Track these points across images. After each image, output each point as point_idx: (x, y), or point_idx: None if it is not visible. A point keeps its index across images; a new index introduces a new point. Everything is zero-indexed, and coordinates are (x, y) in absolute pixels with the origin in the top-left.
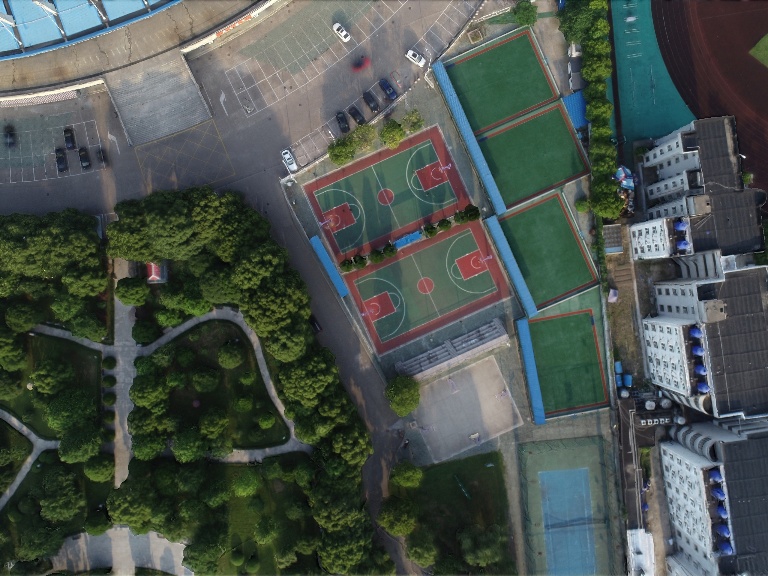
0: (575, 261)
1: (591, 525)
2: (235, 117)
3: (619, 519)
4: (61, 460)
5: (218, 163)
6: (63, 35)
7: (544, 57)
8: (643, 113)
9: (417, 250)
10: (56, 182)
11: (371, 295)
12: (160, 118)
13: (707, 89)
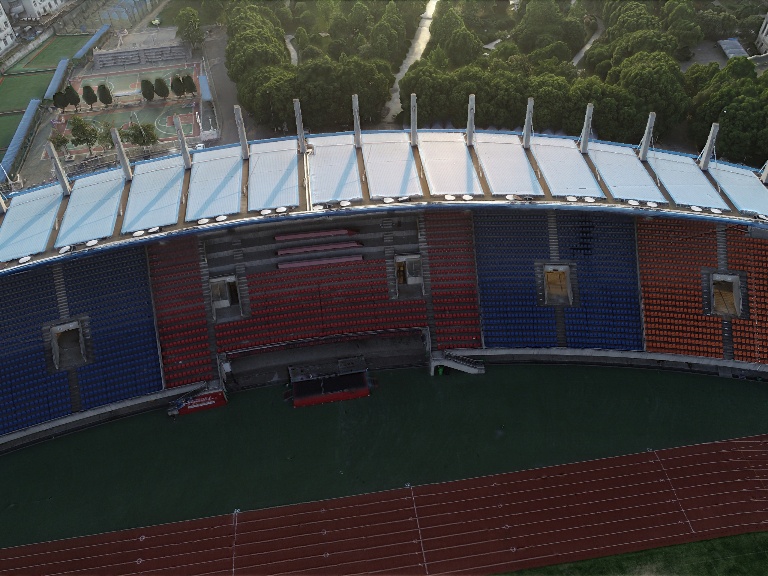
0: (8, 86)
1: (115, 5)
2: None
3: (94, 2)
4: None
5: None
6: None
7: None
8: None
9: None
10: None
11: None
12: None
13: None
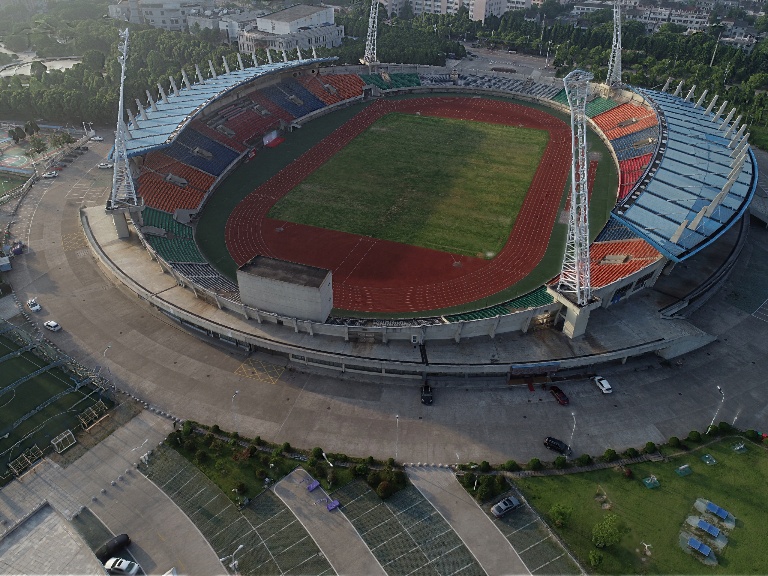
0: None
1: None
2: None
3: None
4: (114, 61)
5: None
6: None
7: None
8: None
9: None
10: None
11: None
12: None
13: None
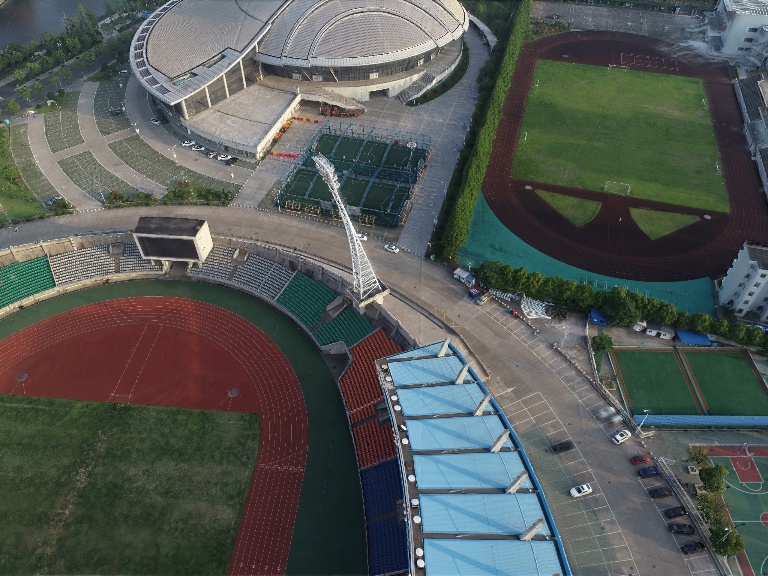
0: None
1: None
2: None
3: None
4: None
5: None
6: None
7: (637, 346)
8: (693, 305)
9: None
10: None
11: None
12: None
13: (677, 267)
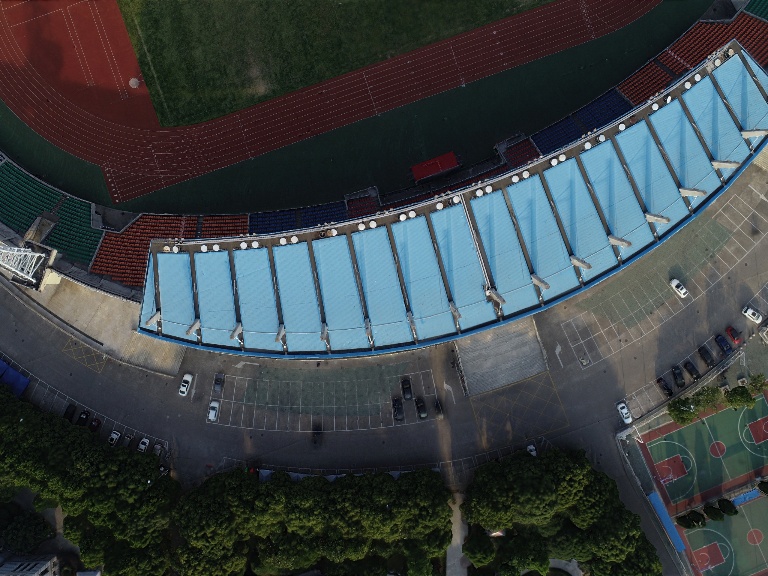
0: None
1: None
2: (570, 369)
3: None
4: None
5: (553, 414)
6: (457, 329)
7: None
8: None
9: (747, 502)
10: (392, 430)
11: (701, 545)
12: (500, 372)
13: None
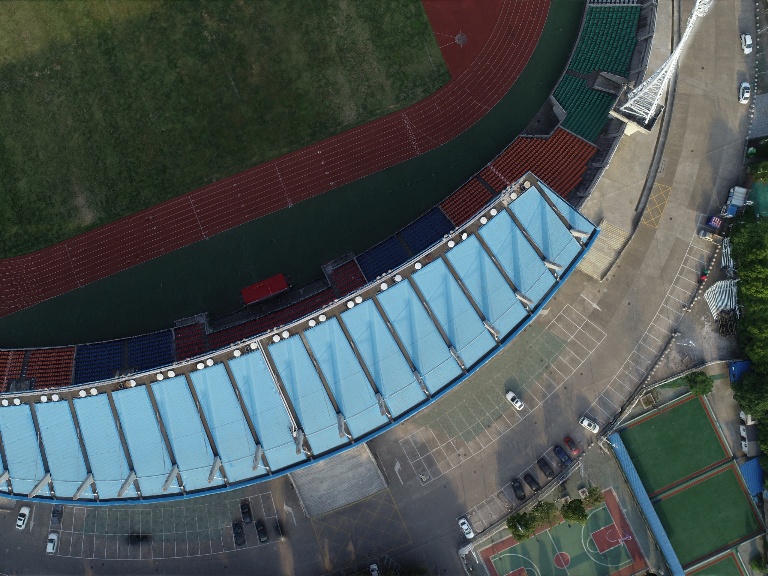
0: None
1: None
2: (410, 485)
3: None
4: None
5: (394, 532)
6: (268, 470)
7: (716, 419)
8: None
9: None
10: (233, 555)
11: None
12: (338, 493)
13: None
